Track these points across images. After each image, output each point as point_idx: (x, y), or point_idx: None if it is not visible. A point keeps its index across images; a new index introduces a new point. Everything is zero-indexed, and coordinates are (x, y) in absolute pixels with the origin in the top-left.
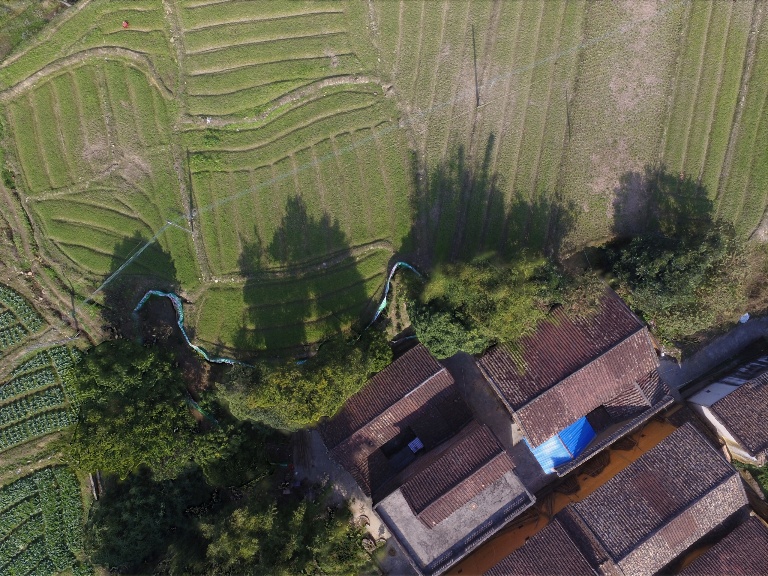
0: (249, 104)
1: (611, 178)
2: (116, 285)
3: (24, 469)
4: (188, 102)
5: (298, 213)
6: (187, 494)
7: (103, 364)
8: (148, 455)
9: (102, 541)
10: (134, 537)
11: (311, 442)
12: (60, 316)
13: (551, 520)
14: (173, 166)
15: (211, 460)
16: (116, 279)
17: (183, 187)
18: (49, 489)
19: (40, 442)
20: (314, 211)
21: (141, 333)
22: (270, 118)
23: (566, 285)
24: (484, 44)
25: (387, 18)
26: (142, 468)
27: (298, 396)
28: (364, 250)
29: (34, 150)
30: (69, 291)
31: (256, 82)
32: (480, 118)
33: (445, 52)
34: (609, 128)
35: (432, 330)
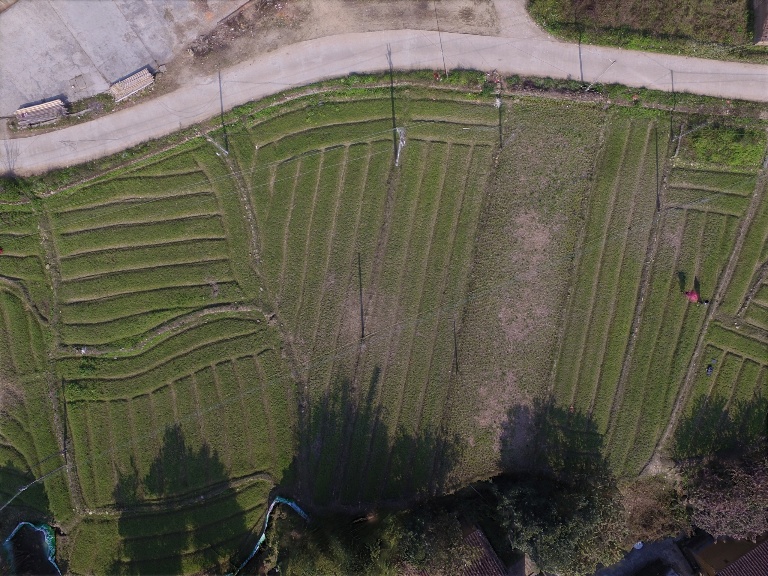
0: (126, 334)
1: (499, 411)
2: None
3: None
4: (63, 331)
5: (176, 444)
6: None
7: None
8: None
9: None
10: None
11: None
12: None
13: None
14: (48, 394)
15: None
16: None
17: (57, 417)
18: None
19: None
20: (193, 442)
21: (13, 564)
22: (149, 346)
23: (434, 556)
24: (371, 272)
25: (270, 246)
26: None
27: None
28: (244, 482)
29: None
30: None
31: (134, 311)
32: (365, 349)
33: (330, 281)
34: (498, 360)
35: None
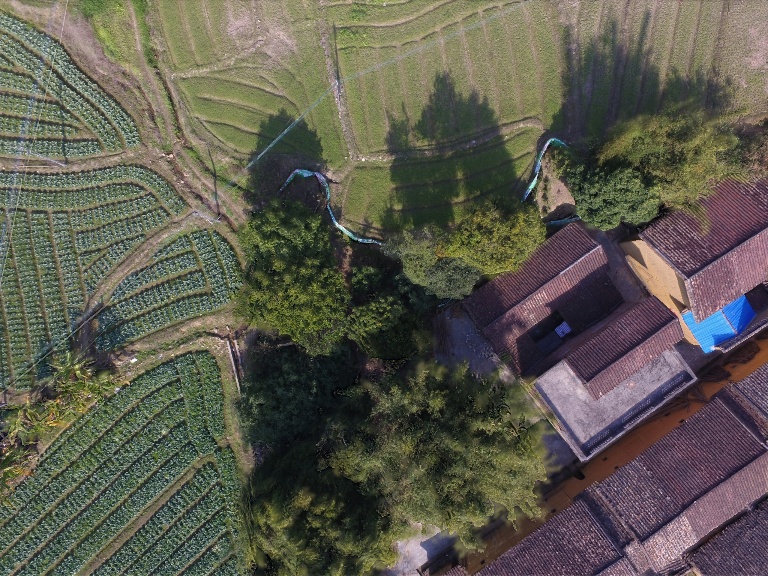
0: None
1: None
2: (262, 164)
3: (165, 354)
4: None
5: (446, 90)
6: (334, 375)
7: (282, 217)
8: (316, 319)
9: (259, 415)
10: (289, 412)
11: (451, 330)
12: (201, 199)
13: (709, 400)
14: (319, 42)
15: (371, 331)
16: (262, 158)
17: (330, 63)
18: (191, 374)
19: (182, 326)
20: (463, 87)
21: None
22: None
23: (744, 146)
24: None
25: None
26: (287, 351)
27: (496, 238)
28: (513, 128)
29: (179, 26)
30: (211, 173)
31: None
32: None
33: None
34: None
35: (608, 191)
